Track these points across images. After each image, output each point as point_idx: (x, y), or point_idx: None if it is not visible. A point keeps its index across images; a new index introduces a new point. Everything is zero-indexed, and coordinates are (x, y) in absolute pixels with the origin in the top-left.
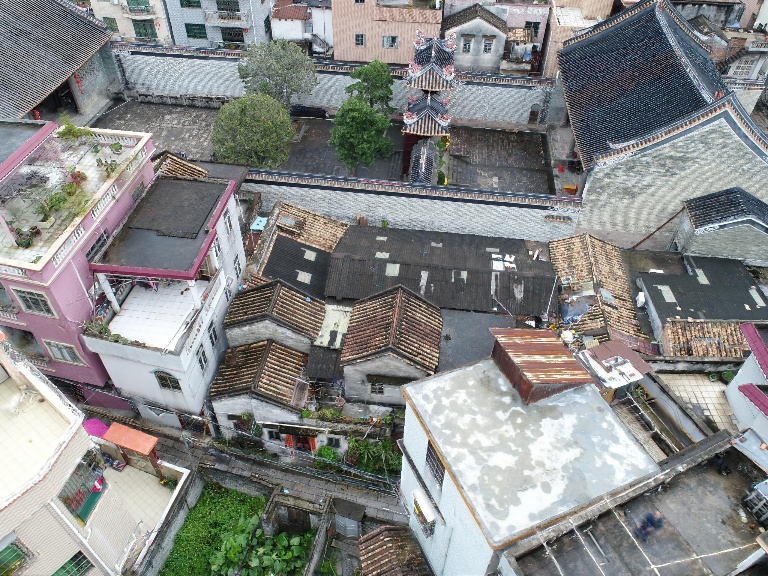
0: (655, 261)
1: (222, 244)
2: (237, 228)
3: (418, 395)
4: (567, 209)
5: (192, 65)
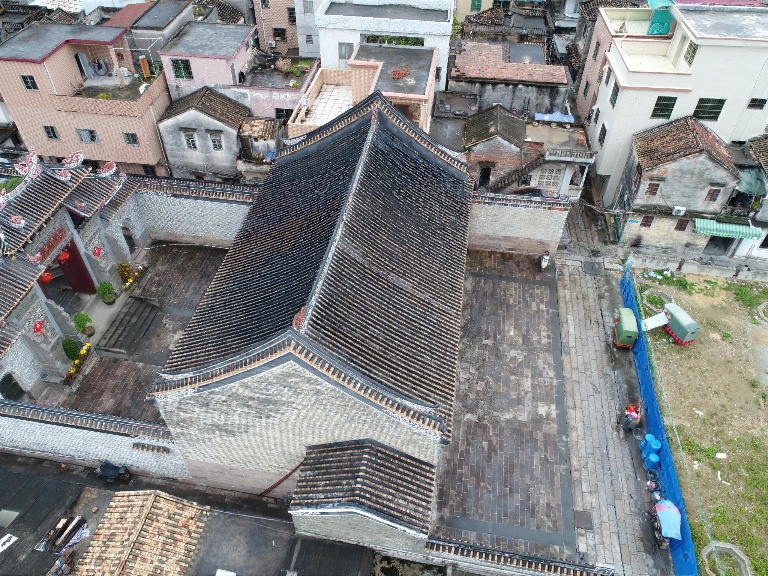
0: (251, 541)
1: None
2: None
3: None
4: (157, 439)
5: None
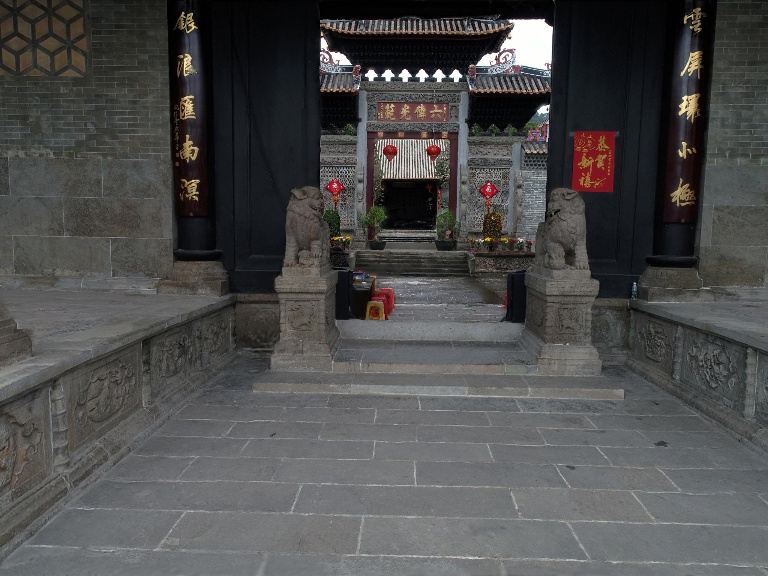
0: None
1: None
2: None
3: None
4: None
5: None
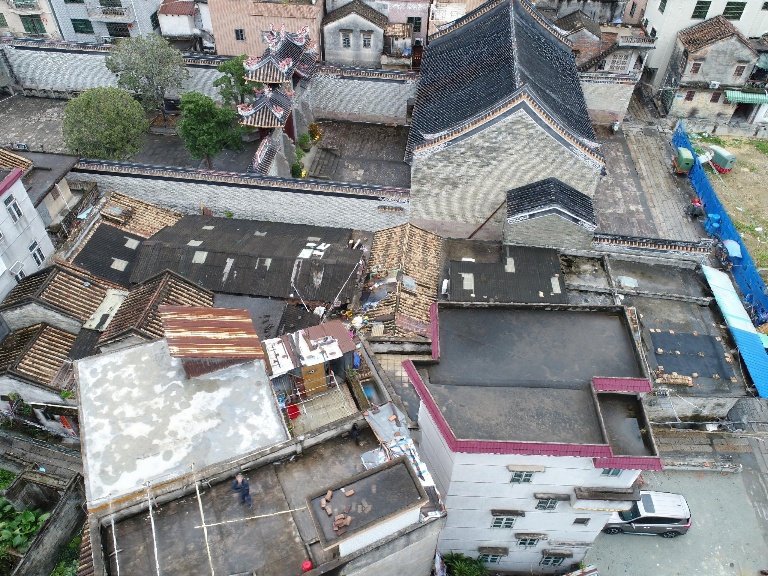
0: (474, 250)
1: (4, 230)
2: (33, 215)
3: (87, 369)
4: (397, 199)
5: (75, 60)
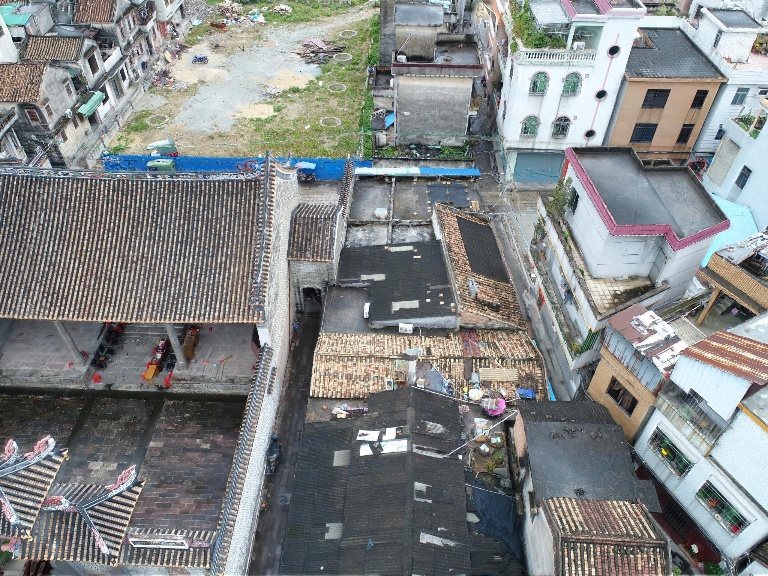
0: (341, 308)
1: None
2: None
3: None
4: None
5: None
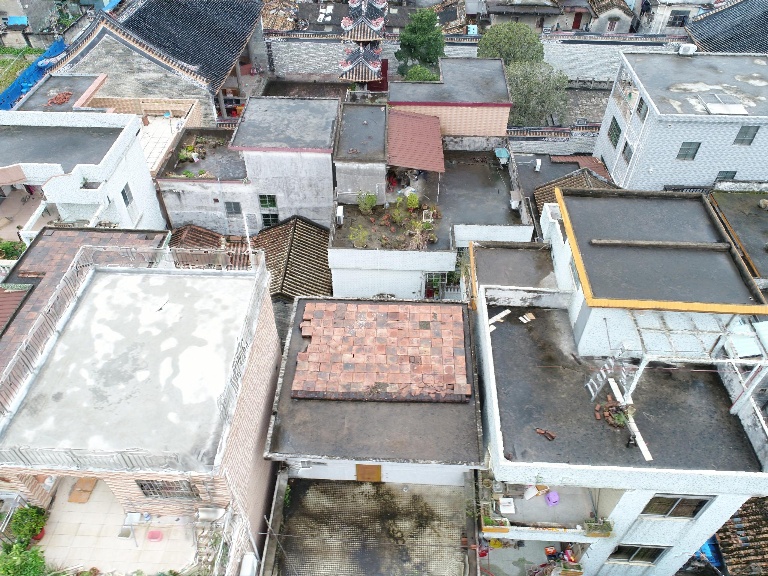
0: None
1: None
2: None
3: None
4: None
5: None
